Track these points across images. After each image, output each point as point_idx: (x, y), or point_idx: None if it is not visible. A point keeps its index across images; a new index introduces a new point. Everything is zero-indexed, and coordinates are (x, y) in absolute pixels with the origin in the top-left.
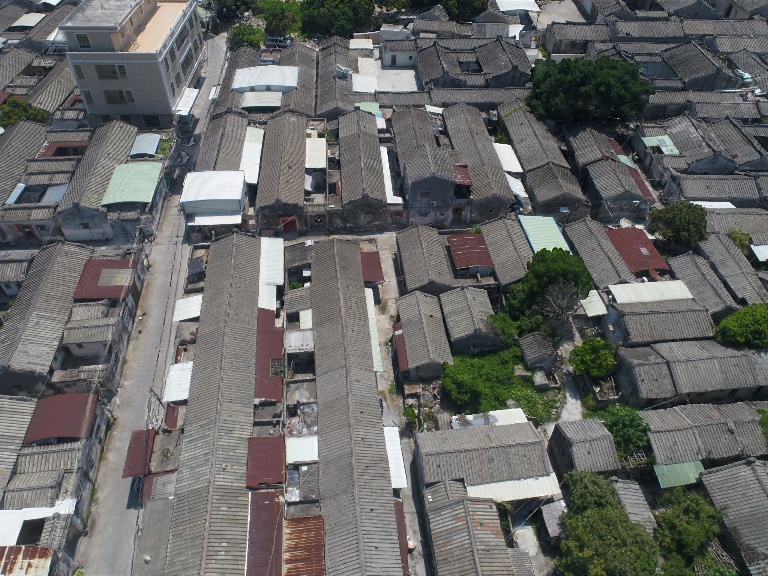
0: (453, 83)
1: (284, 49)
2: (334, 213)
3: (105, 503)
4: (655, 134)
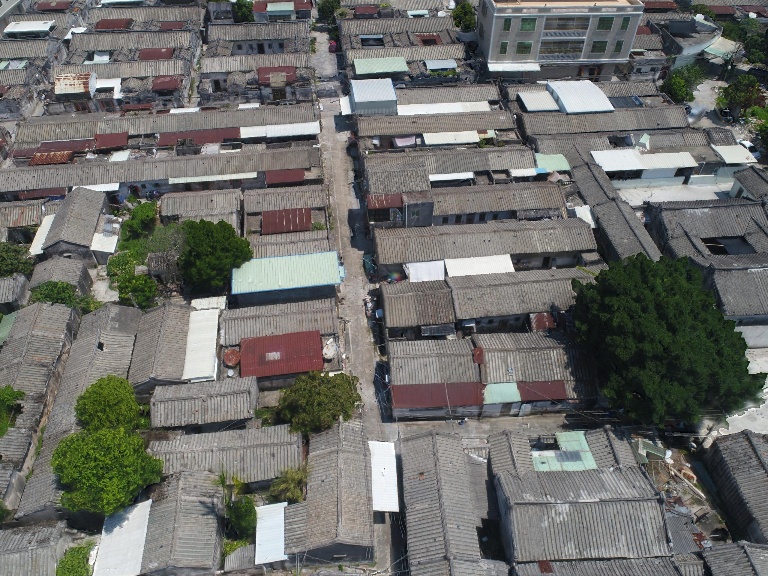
0: (660, 226)
1: (672, 105)
2: None
3: None
4: (596, 450)
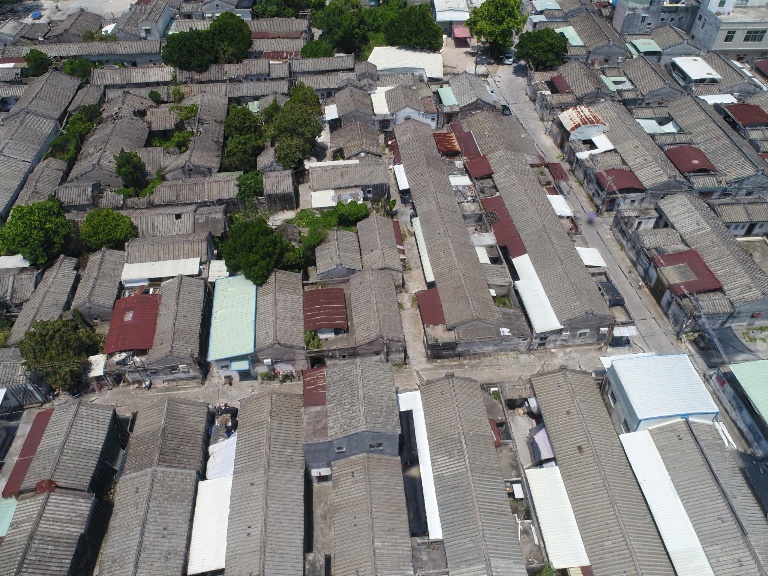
0: None
1: None
2: (489, 385)
3: (570, 181)
4: None
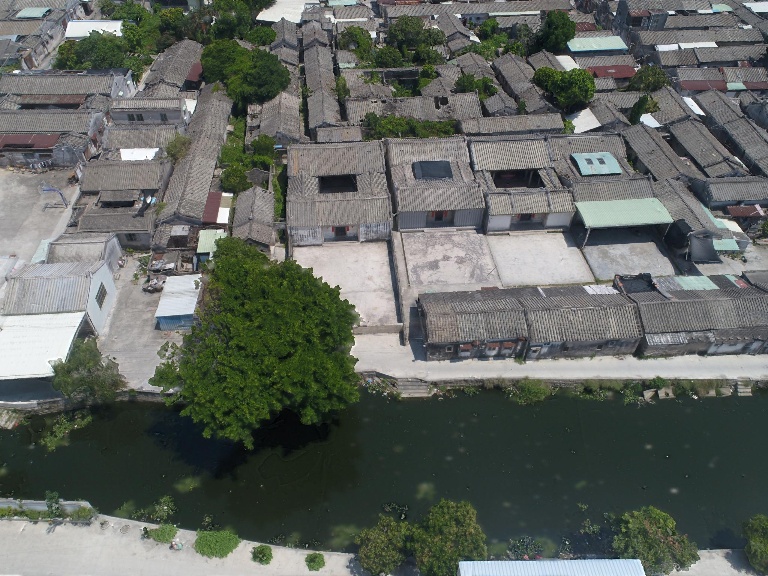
0: None
1: None
2: None
3: None
4: None
